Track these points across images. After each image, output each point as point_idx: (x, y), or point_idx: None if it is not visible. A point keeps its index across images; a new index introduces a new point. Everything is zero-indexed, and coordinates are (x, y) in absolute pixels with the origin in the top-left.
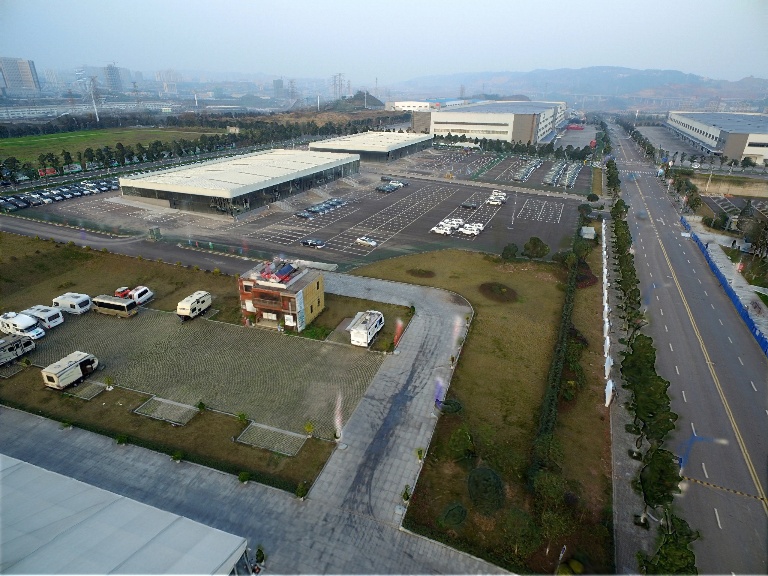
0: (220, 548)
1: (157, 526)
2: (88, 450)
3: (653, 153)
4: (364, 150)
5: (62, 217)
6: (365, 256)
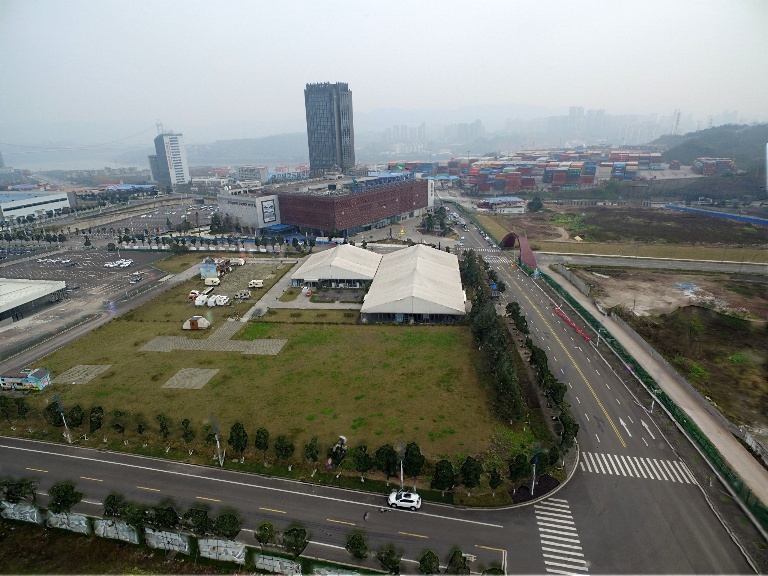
0: None
1: None
2: None
3: None
4: None
5: (21, 345)
6: None
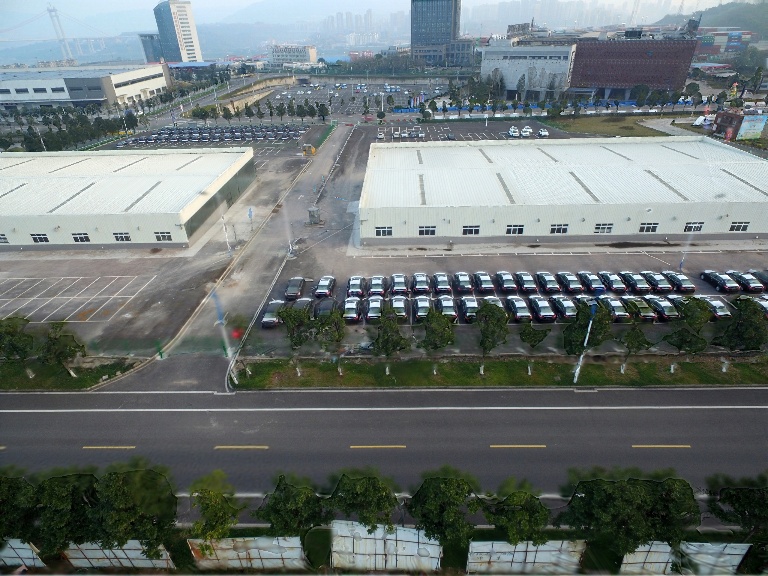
0: None
1: None
2: None
3: (108, 109)
4: (239, 169)
5: None
6: None
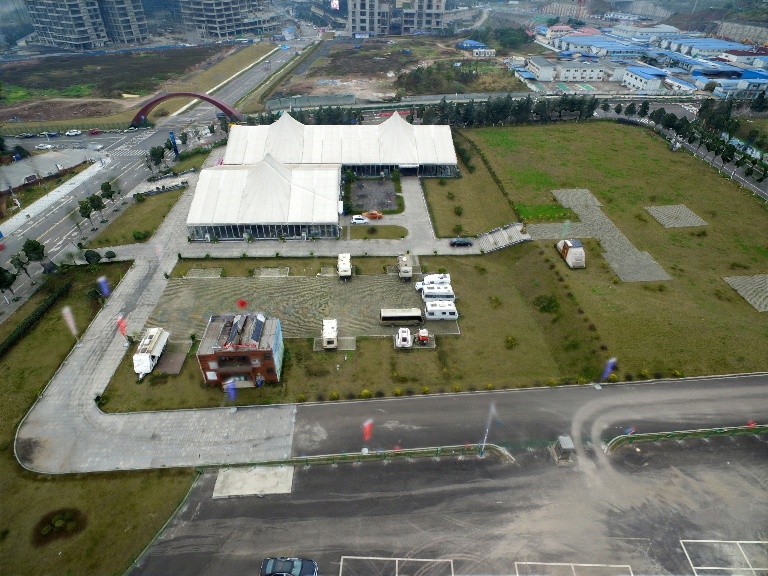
0: (192, 218)
1: (217, 218)
2: (292, 252)
3: None
4: None
5: None
6: (167, 575)
